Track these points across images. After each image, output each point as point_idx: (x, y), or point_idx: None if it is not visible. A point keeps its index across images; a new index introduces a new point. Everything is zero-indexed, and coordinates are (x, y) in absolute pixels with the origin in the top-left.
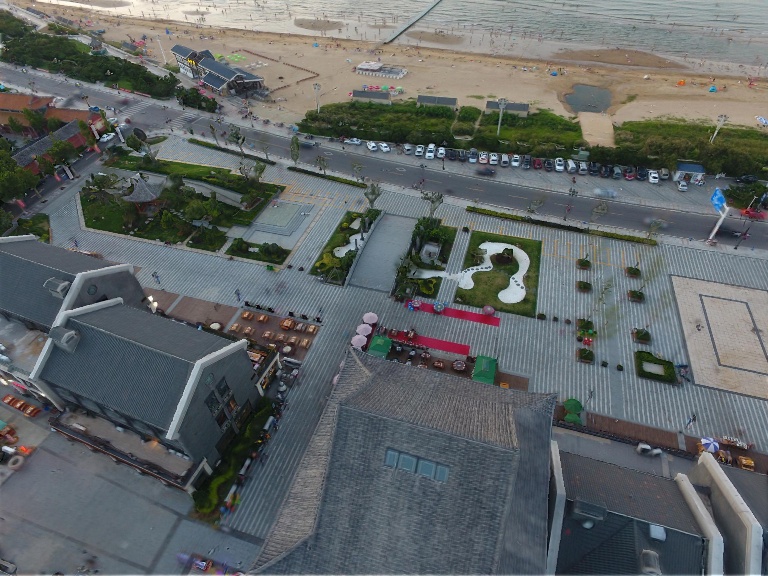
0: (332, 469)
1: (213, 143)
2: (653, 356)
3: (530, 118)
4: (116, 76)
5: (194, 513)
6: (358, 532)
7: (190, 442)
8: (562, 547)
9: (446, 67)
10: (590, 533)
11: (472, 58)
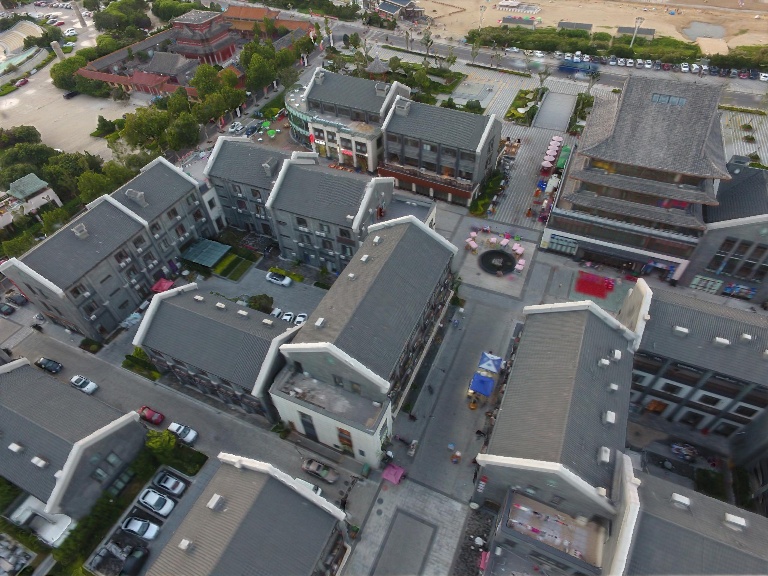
0: (622, 107)
1: (402, 48)
2: (762, 165)
3: (655, 40)
4: (305, 5)
5: (470, 214)
6: (635, 133)
7: (480, 164)
8: (721, 184)
9: (574, 7)
10: (737, 177)
11: (596, 1)
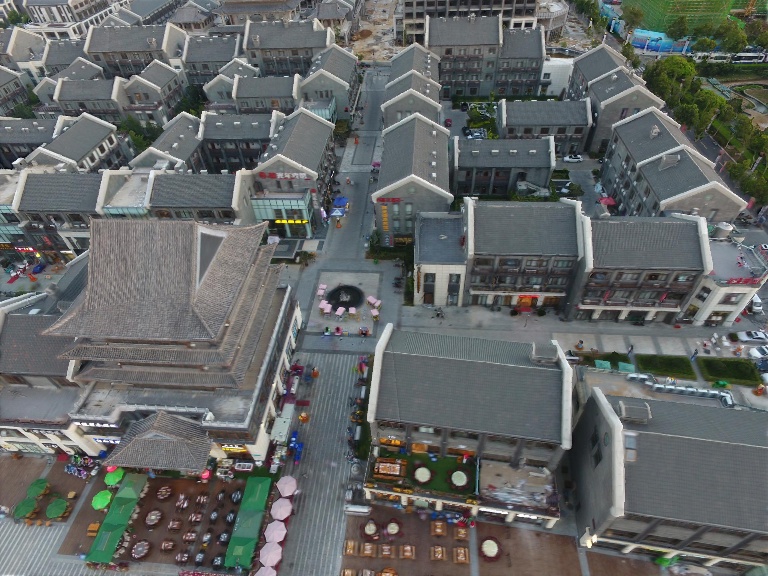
0: None
1: None
2: None
3: None
4: None
5: None
6: None
7: None
8: None
9: None
10: None
11: None
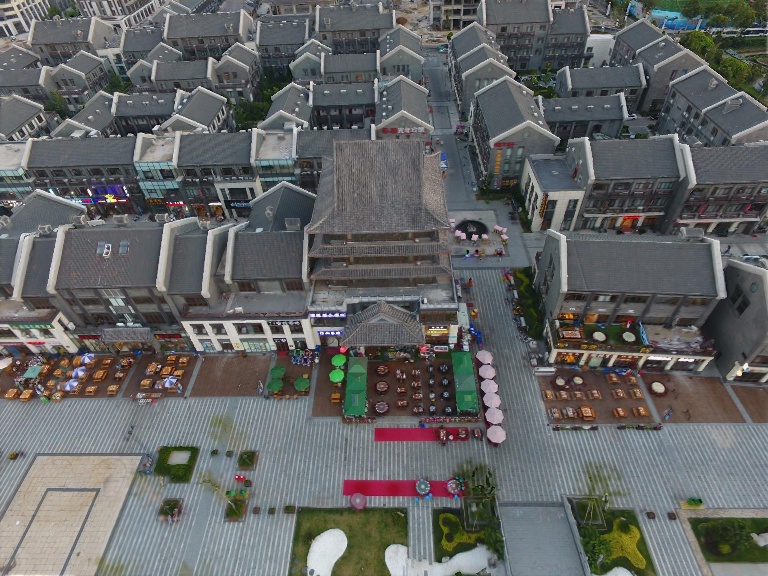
0: None
1: None
2: (173, 472)
3: None
4: None
5: None
6: None
7: None
8: None
9: None
10: None
11: None
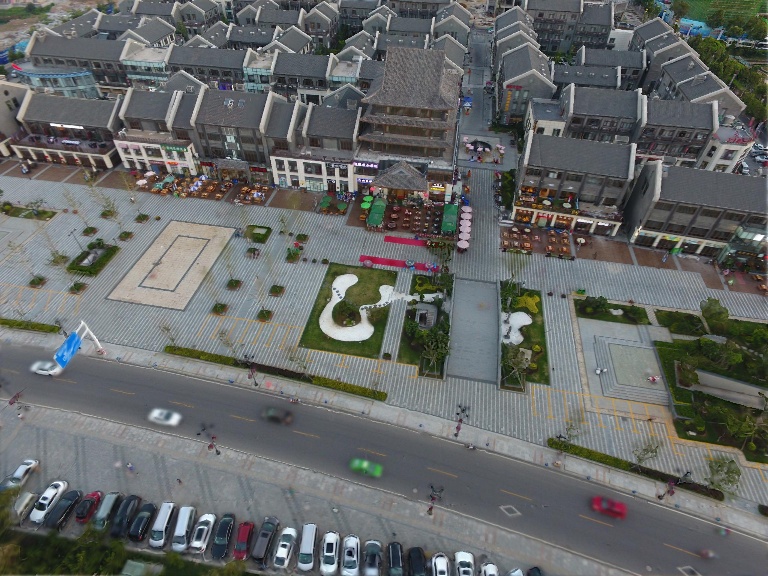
0: None
1: None
2: (256, 236)
3: None
4: None
5: None
6: None
7: None
8: None
9: None
10: None
11: None
